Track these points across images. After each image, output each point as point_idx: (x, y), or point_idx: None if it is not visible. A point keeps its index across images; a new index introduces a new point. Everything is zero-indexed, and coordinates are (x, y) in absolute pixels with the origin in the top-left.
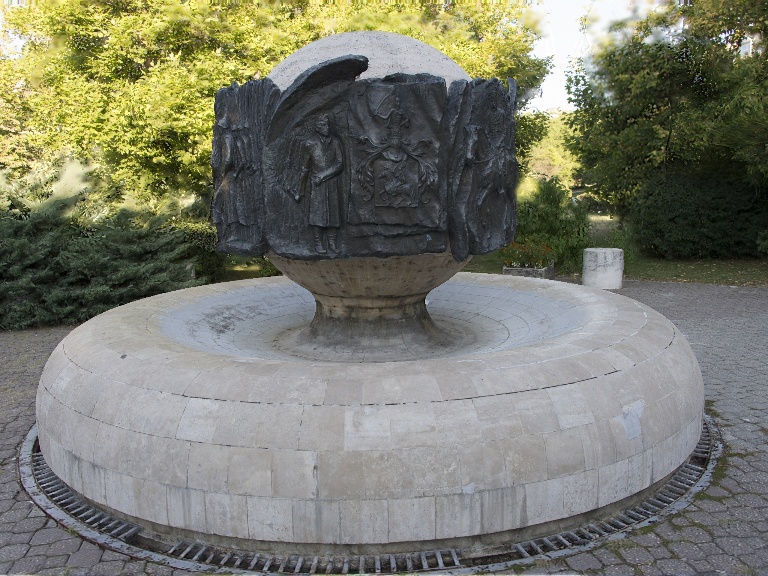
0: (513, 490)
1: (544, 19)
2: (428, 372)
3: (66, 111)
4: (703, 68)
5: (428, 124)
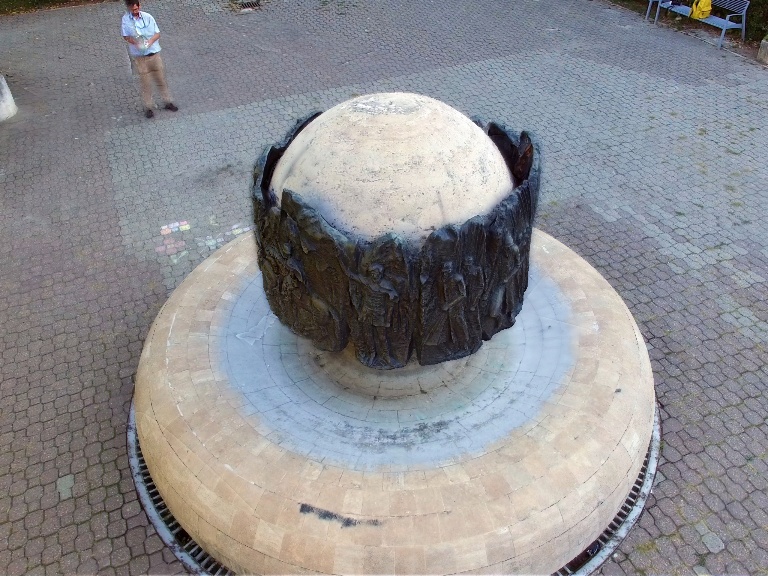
0: None
1: None
2: (571, 260)
3: None
4: None
5: None
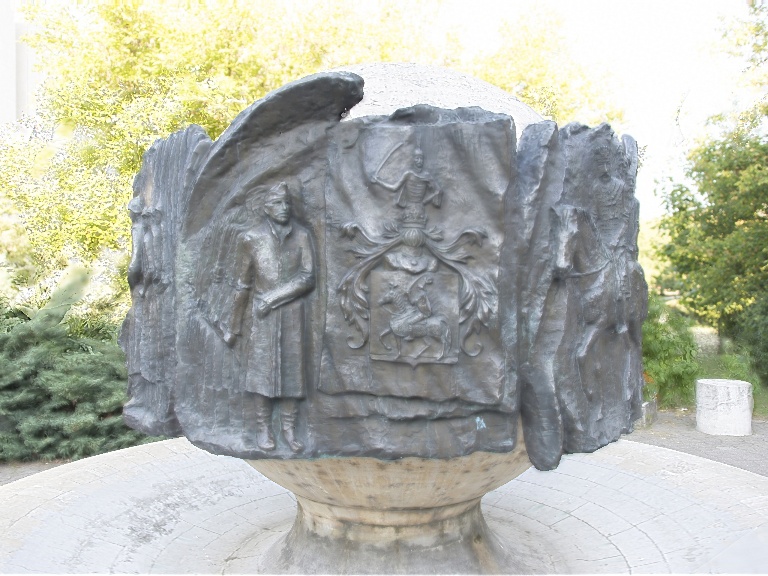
0: None
1: (633, 105)
2: None
3: (67, 206)
4: None
5: (479, 200)
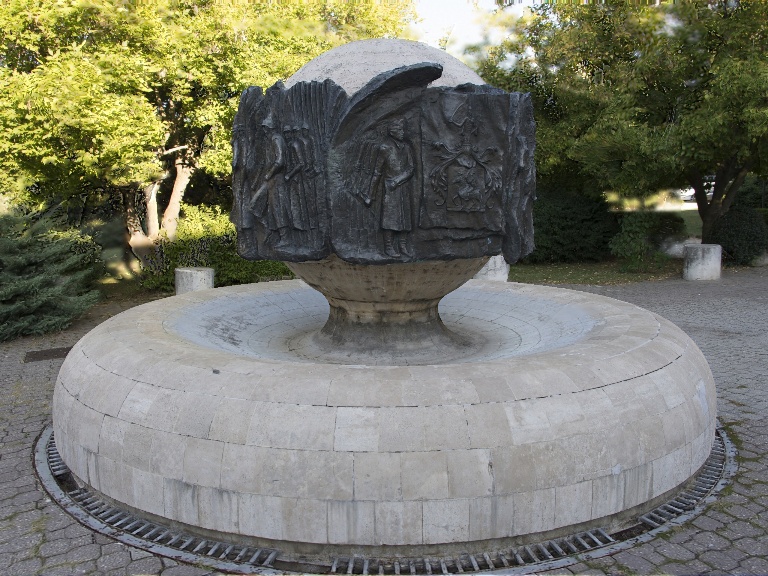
0: (645, 467)
1: (424, 38)
2: (551, 366)
3: None
4: (555, 93)
5: (493, 133)
